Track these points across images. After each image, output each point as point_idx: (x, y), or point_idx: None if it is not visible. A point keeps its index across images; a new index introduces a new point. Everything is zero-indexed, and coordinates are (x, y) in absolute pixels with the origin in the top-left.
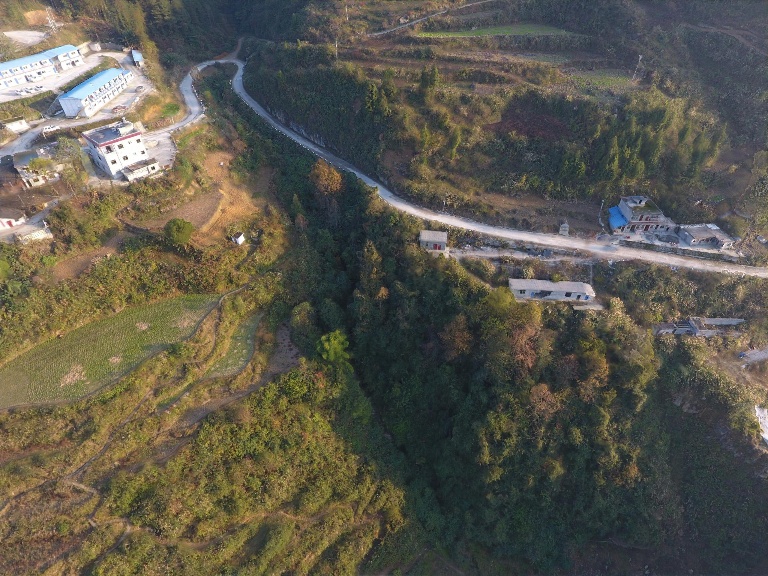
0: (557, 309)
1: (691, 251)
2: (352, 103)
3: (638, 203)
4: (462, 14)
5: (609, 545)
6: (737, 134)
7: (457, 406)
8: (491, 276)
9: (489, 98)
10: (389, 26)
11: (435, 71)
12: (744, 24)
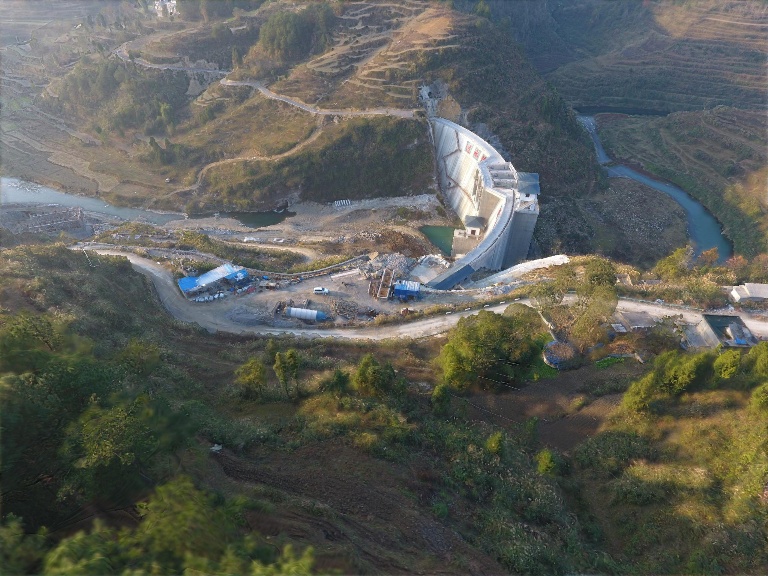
0: None
1: None
2: None
3: None
4: None
5: None
6: (555, 475)
7: None
8: None
9: None
10: None
11: None
12: None
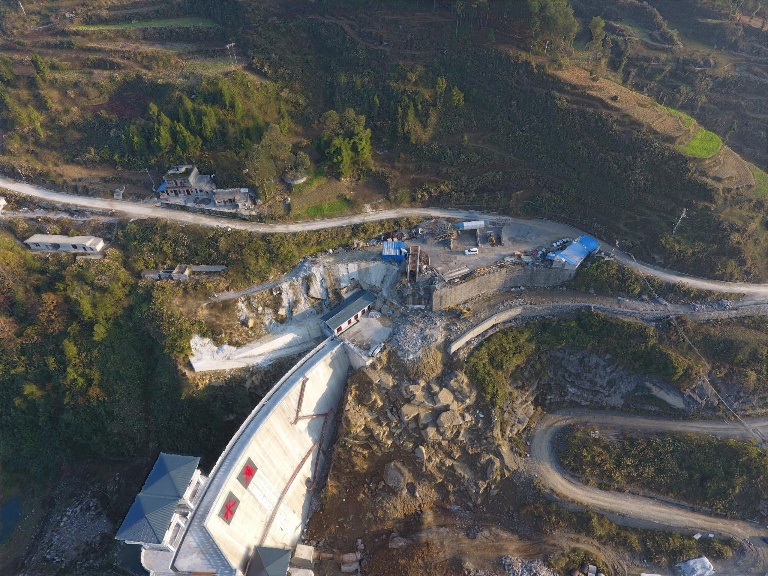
0: (60, 259)
1: (214, 211)
2: None
3: (177, 170)
4: (126, 9)
5: (102, 459)
6: None
7: None
8: (22, 233)
9: (97, 82)
10: (56, 20)
11: (37, 58)
12: (352, 15)
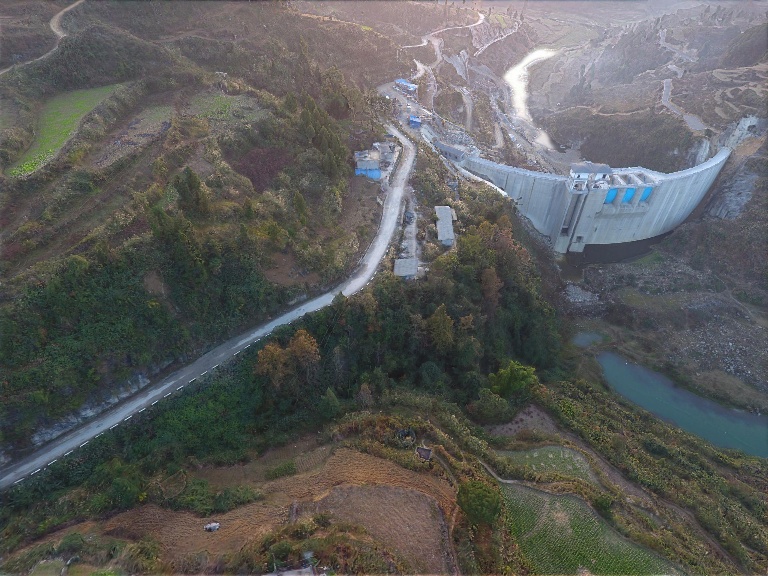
0: None
1: None
2: (146, 289)
3: (367, 156)
4: None
5: None
6: None
7: (512, 319)
8: None
9: (221, 168)
10: None
11: (193, 172)
12: (187, 26)
